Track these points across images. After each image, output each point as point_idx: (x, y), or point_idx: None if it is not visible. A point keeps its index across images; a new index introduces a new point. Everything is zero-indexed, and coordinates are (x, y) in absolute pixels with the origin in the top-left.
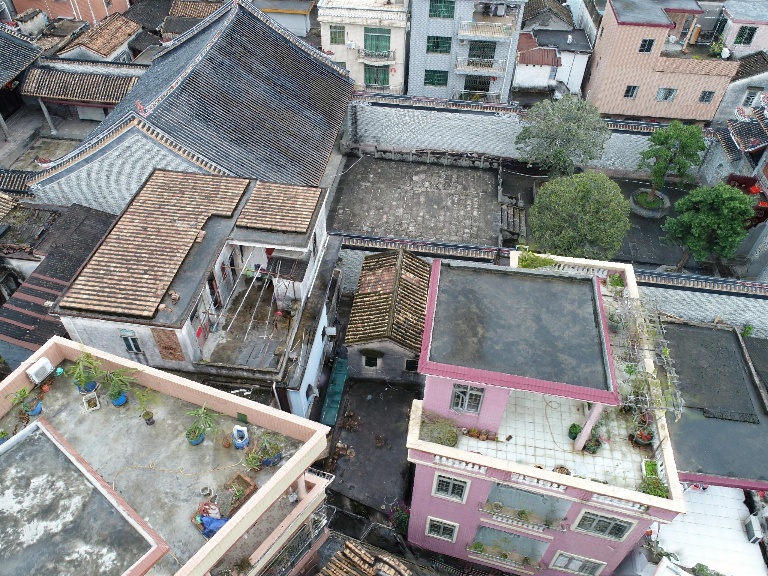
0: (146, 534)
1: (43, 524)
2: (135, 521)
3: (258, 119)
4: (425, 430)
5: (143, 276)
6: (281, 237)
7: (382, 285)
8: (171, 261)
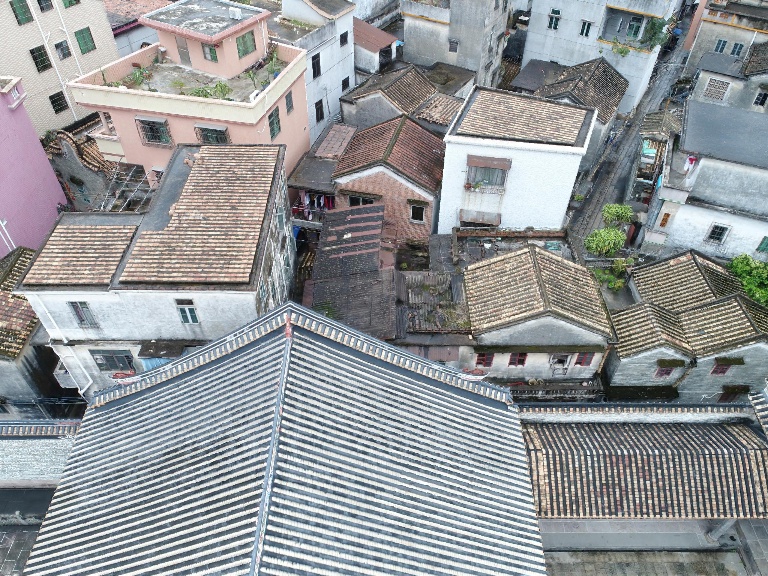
0: (146, 18)
1: (194, 21)
2: (152, 20)
3: (128, 568)
4: (7, 82)
5: (219, 169)
6: (88, 222)
7: (6, 304)
8: (197, 182)
